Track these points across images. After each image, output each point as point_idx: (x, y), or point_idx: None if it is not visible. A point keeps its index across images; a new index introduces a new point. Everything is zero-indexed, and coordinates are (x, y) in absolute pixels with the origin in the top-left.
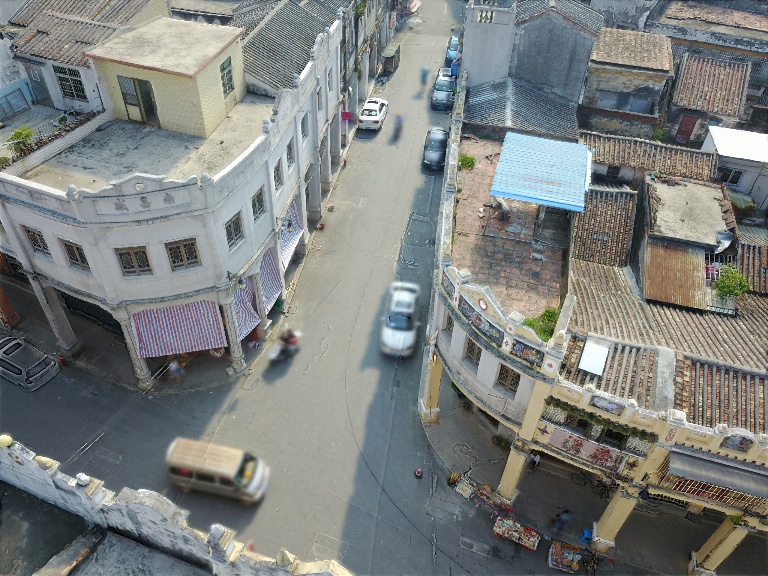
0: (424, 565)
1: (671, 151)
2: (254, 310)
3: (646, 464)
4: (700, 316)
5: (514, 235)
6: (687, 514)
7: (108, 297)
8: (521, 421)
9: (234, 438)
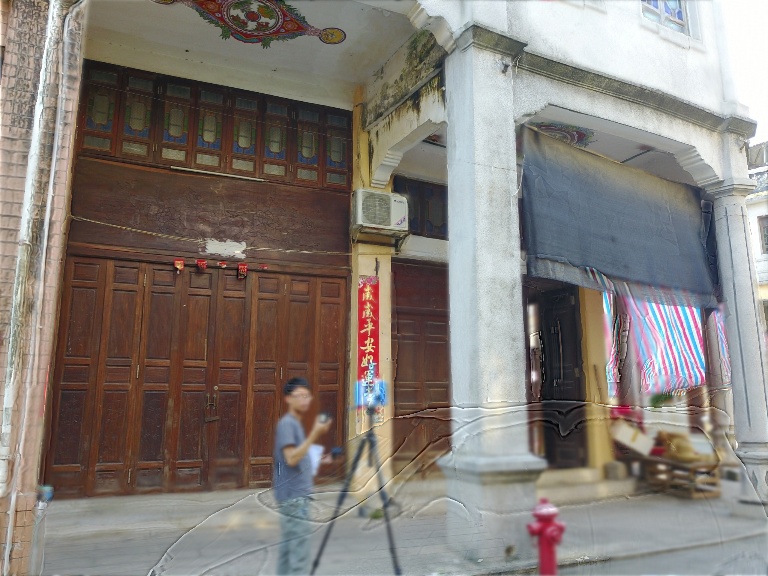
0: None
1: None
2: None
3: None
4: None
5: None
6: None
7: (735, 101)
8: None
9: None
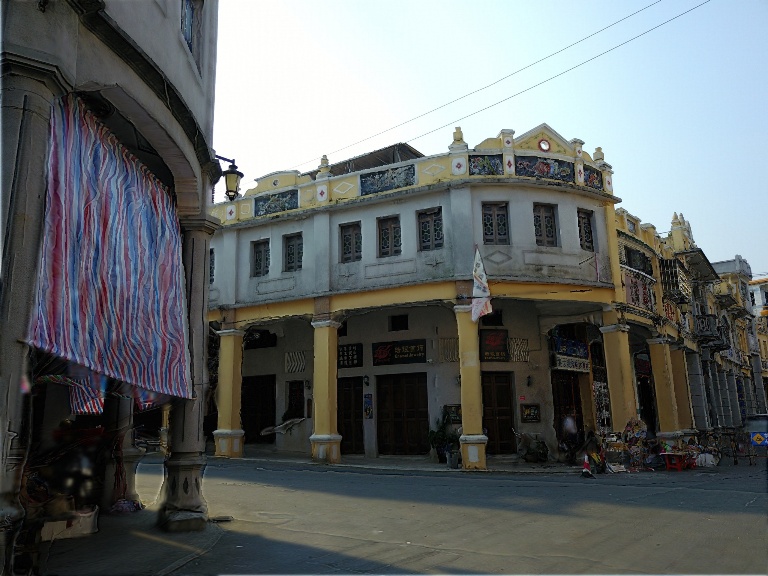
0: (760, 482)
1: None
2: None
3: None
4: None
5: None
6: None
7: None
8: (610, 280)
9: None
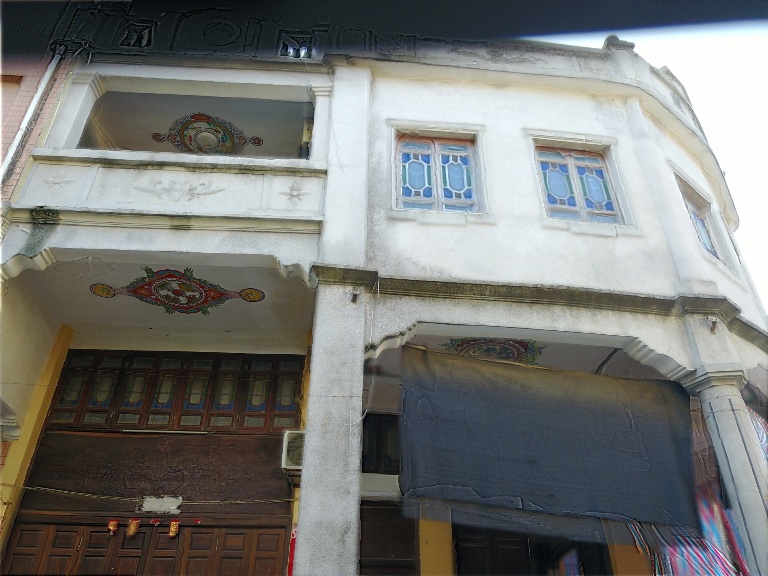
0: None
1: None
2: None
3: None
4: None
5: None
6: None
7: (693, 278)
8: None
9: None
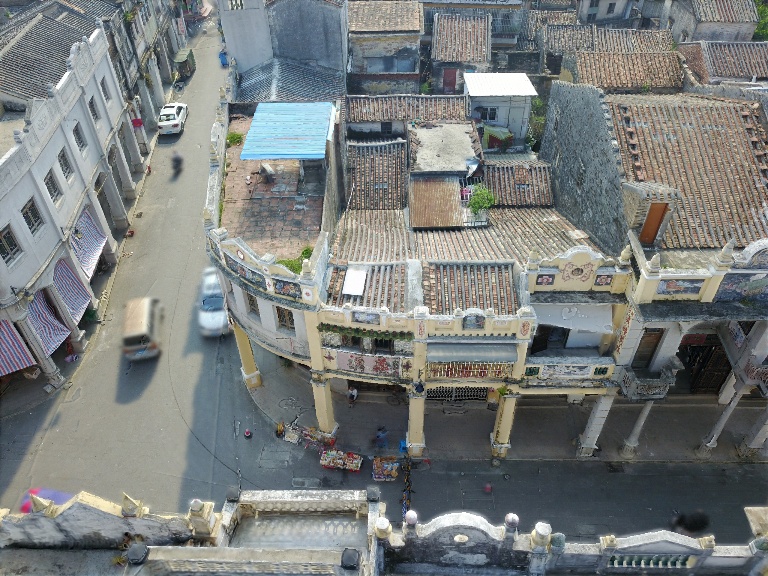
0: None
1: (431, 100)
2: (60, 323)
3: (415, 362)
4: (458, 232)
5: (279, 193)
6: (488, 405)
7: None
8: (309, 355)
9: (59, 450)
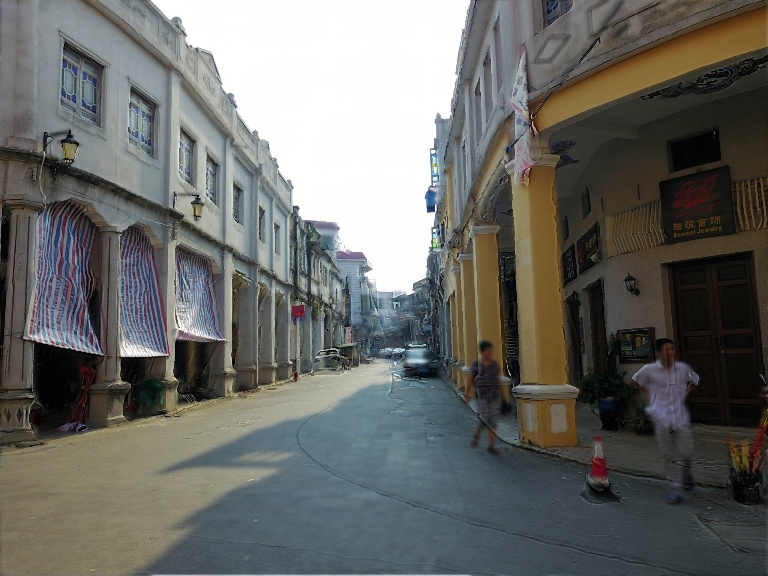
0: None
1: None
2: None
3: None
4: None
5: None
6: None
7: None
8: None
9: None
